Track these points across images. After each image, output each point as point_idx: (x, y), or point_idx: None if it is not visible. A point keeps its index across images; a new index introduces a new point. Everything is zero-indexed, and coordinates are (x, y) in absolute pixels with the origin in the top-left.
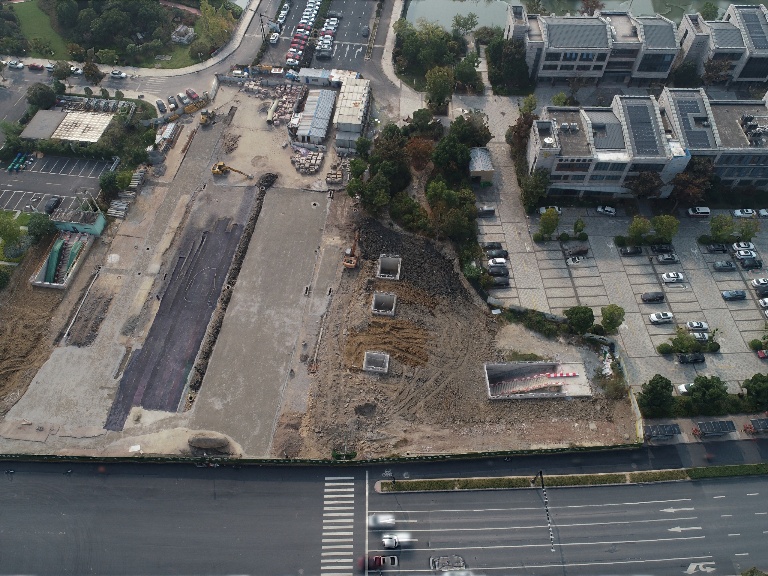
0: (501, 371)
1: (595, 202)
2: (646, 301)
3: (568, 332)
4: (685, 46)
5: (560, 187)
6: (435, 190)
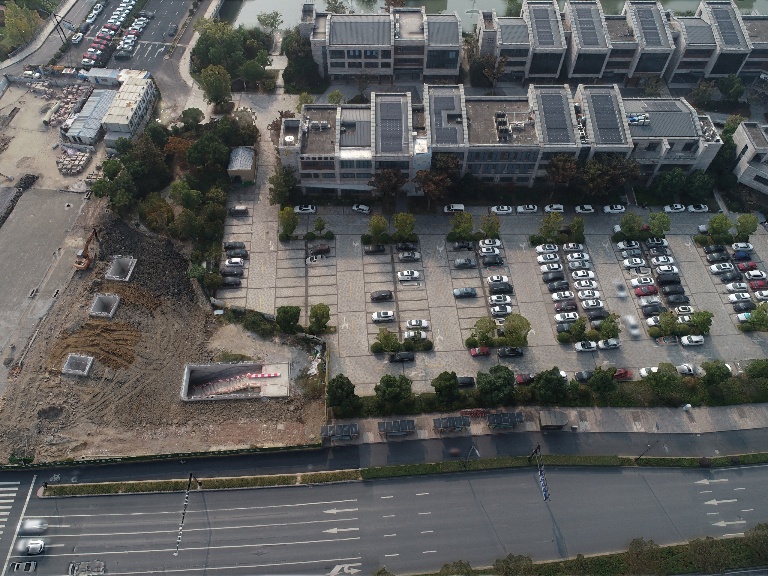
0: (210, 372)
1: (353, 200)
2: (374, 300)
3: (283, 332)
4: (479, 42)
5: (314, 185)
6: (176, 190)
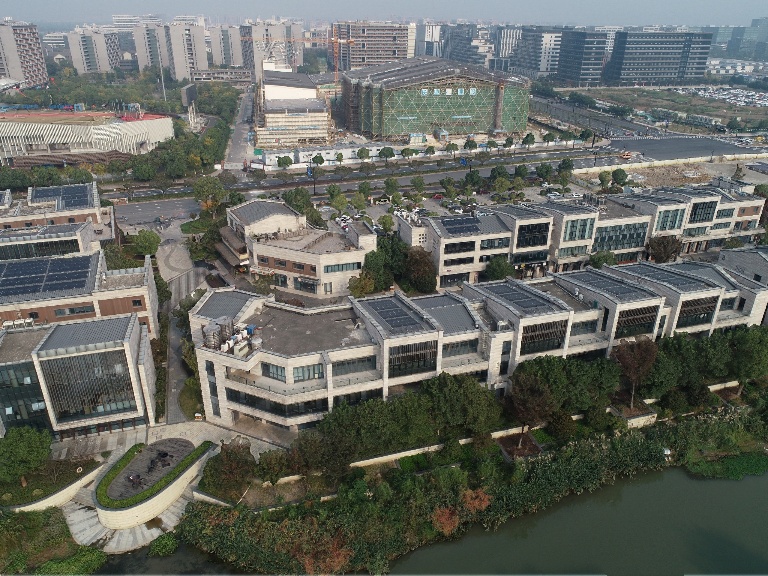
0: None
1: None
2: None
3: None
4: None
5: None
6: None
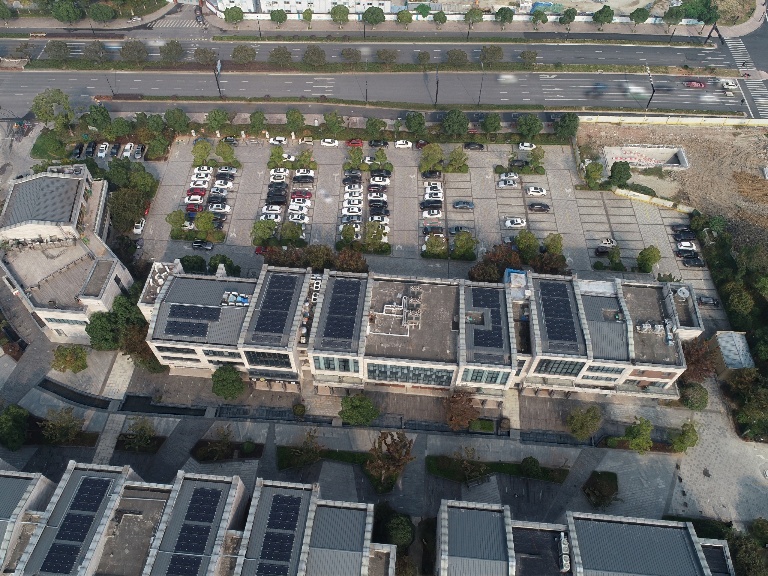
0: None
1: None
2: None
3: None
4: None
5: None
6: None
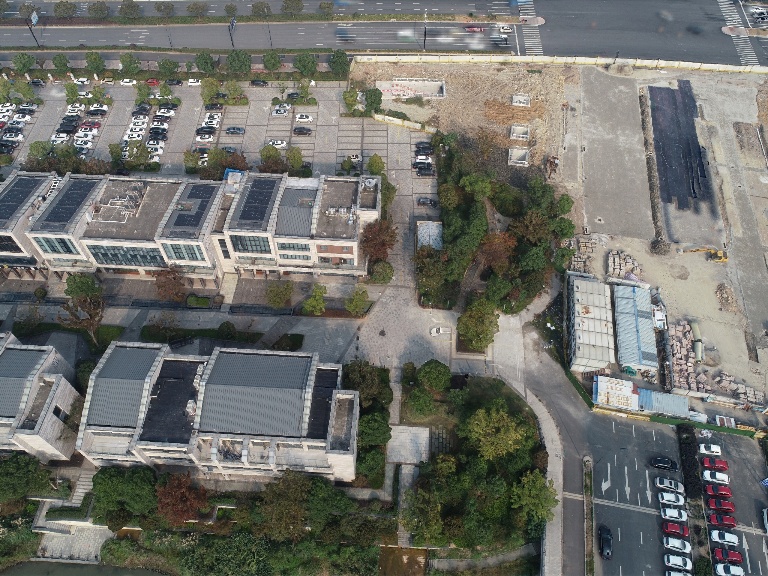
0: None
1: None
2: None
3: None
4: None
5: None
6: None
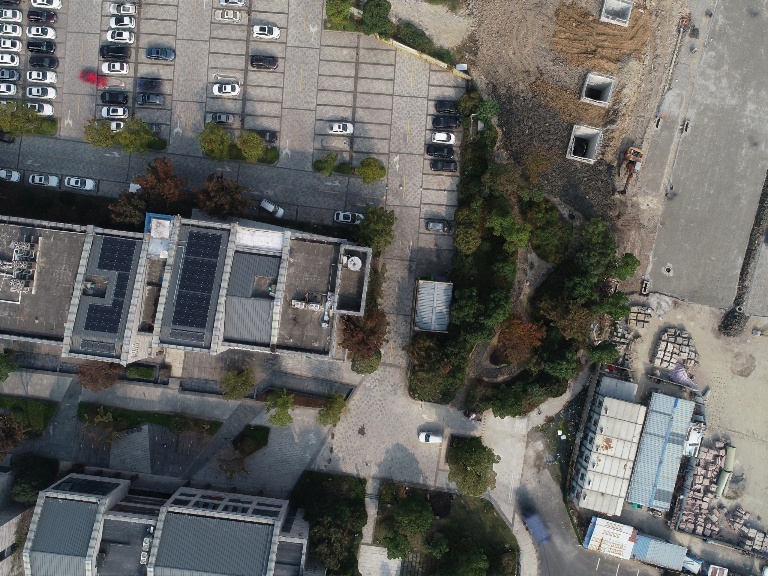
0: None
1: None
2: None
3: None
4: (12, 535)
5: None
6: None
